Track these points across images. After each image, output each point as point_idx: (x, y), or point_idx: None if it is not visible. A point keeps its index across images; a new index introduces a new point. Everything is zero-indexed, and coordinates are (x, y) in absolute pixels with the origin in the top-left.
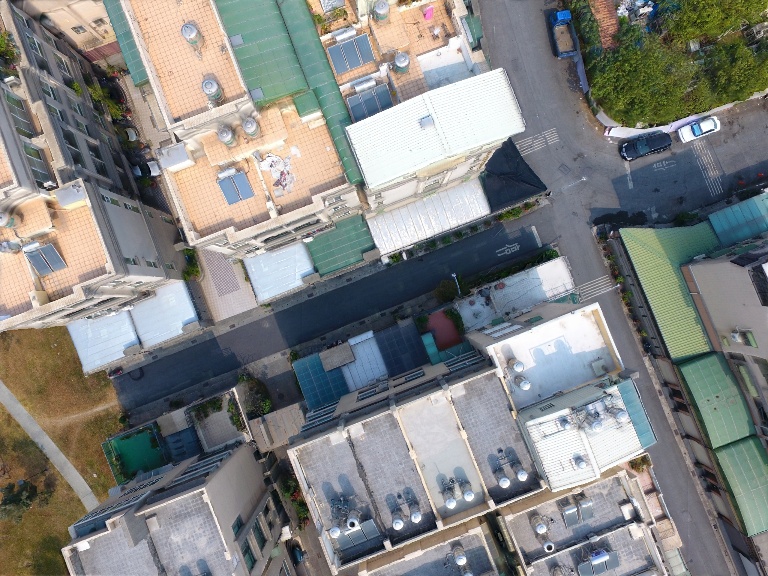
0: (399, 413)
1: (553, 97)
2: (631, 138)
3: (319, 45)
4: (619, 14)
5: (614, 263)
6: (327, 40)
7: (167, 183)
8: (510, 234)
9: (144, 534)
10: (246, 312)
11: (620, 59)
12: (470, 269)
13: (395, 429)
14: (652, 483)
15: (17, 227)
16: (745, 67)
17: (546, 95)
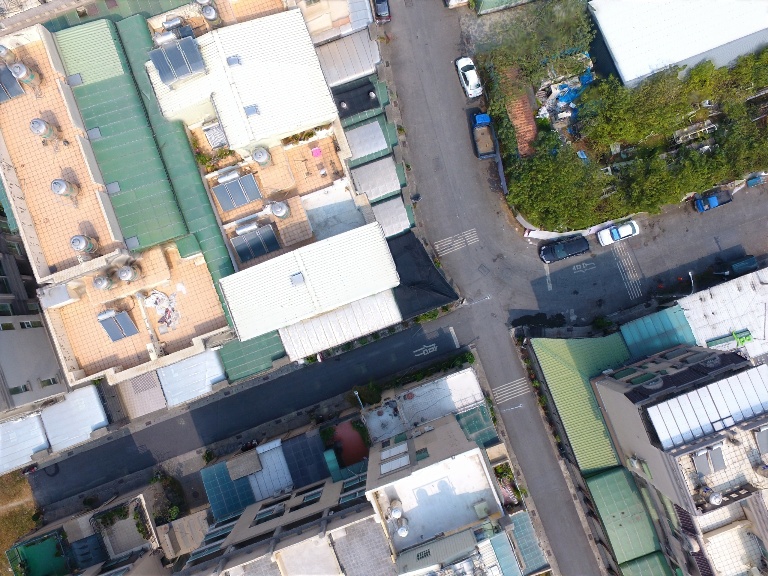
0: (277, 556)
1: (473, 197)
2: (551, 240)
3: (200, 189)
4: (540, 116)
5: (530, 367)
6: (214, 176)
7: (48, 323)
8: (428, 335)
9: None
10: (162, 409)
11: (534, 169)
12: (387, 369)
13: (276, 569)
14: None
15: None
16: (657, 181)
17: (466, 195)
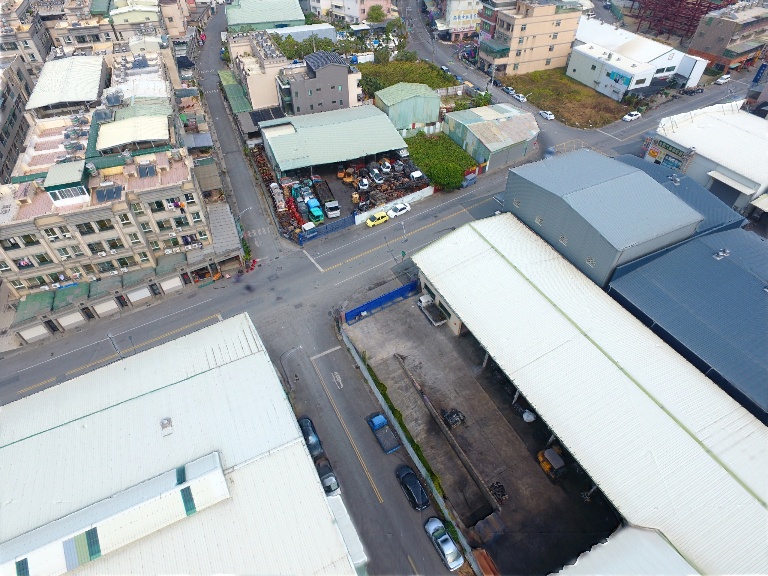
0: (94, 46)
1: (216, 65)
2: None
3: None
4: None
5: None
6: None
7: None
8: None
9: None
10: None
11: None
12: None
13: None
14: None
15: (7, 25)
16: None
17: (214, 65)
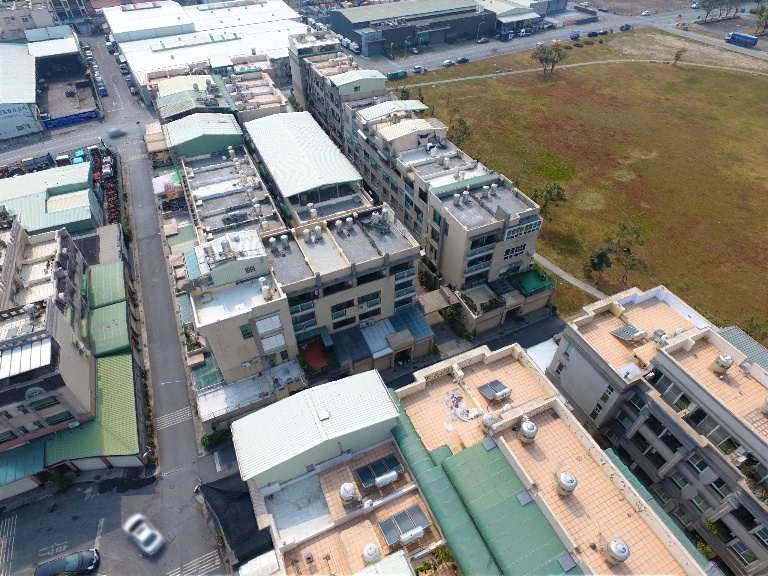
0: None
1: None
2: None
3: (439, 515)
4: None
5: (149, 437)
6: None
7: None
8: None
9: (497, 215)
10: None
11: None
12: None
13: None
14: (177, 283)
15: None
16: None
17: None
